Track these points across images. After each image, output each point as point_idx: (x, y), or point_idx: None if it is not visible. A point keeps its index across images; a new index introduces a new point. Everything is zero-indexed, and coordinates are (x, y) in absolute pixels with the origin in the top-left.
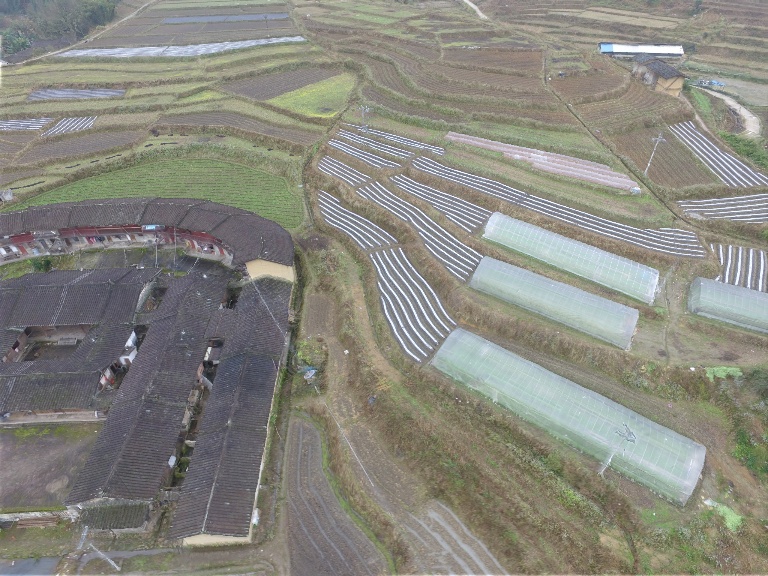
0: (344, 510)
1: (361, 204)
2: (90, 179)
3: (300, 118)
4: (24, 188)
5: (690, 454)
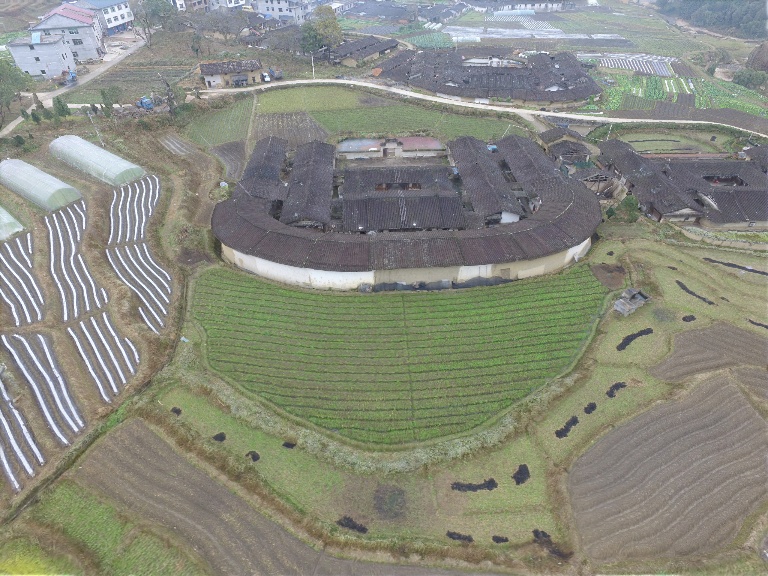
0: (220, 159)
1: (115, 280)
2: (558, 373)
3: (98, 566)
4: (629, 332)
5: (62, 138)
